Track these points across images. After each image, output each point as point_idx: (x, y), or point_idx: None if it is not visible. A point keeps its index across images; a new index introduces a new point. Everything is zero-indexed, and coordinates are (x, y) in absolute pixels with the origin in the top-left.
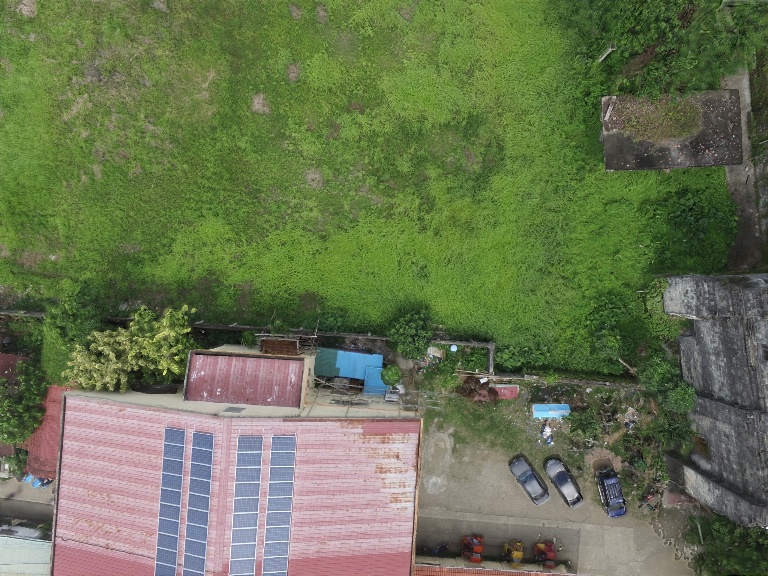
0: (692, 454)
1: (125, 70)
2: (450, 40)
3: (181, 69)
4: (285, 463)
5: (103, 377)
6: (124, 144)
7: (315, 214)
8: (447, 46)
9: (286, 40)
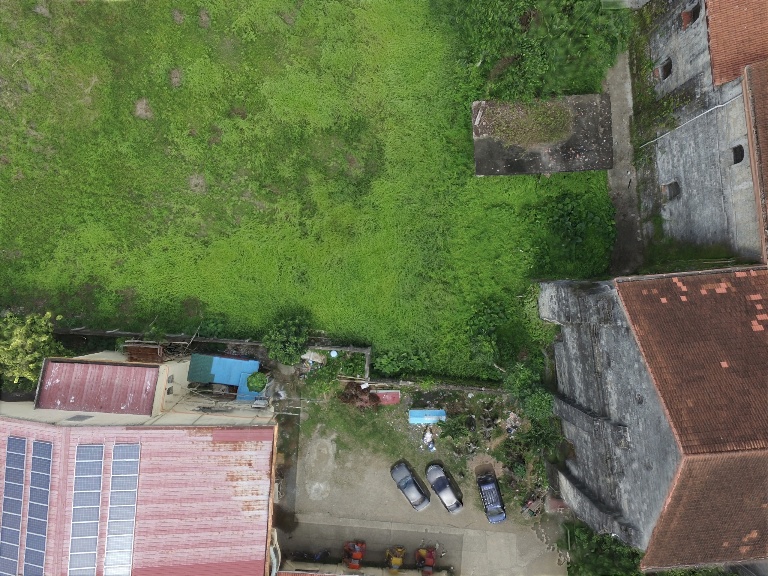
0: (567, 459)
1: (7, 75)
2: (331, 45)
3: (63, 74)
4: (128, 472)
5: None
6: (6, 150)
7: (197, 219)
8: (327, 51)
9: (168, 45)
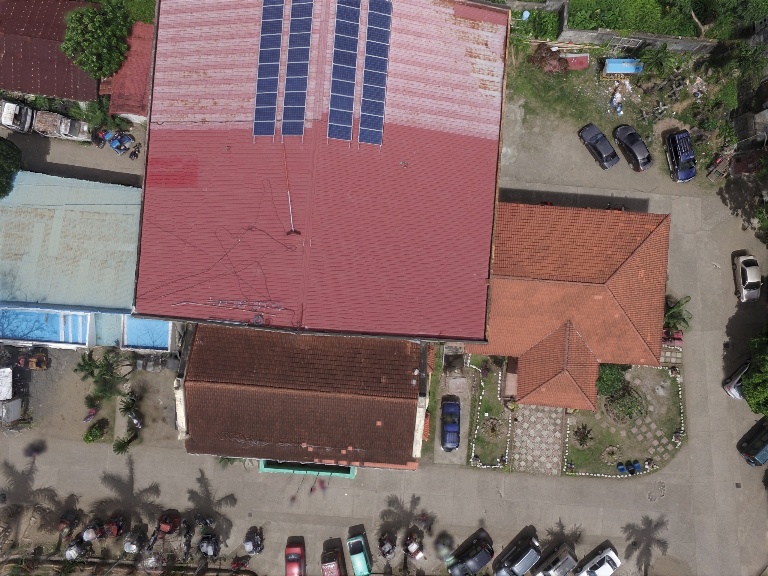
0: (764, 103)
1: None
2: None
3: None
4: (381, 26)
5: None
6: None
7: None
8: None
9: None
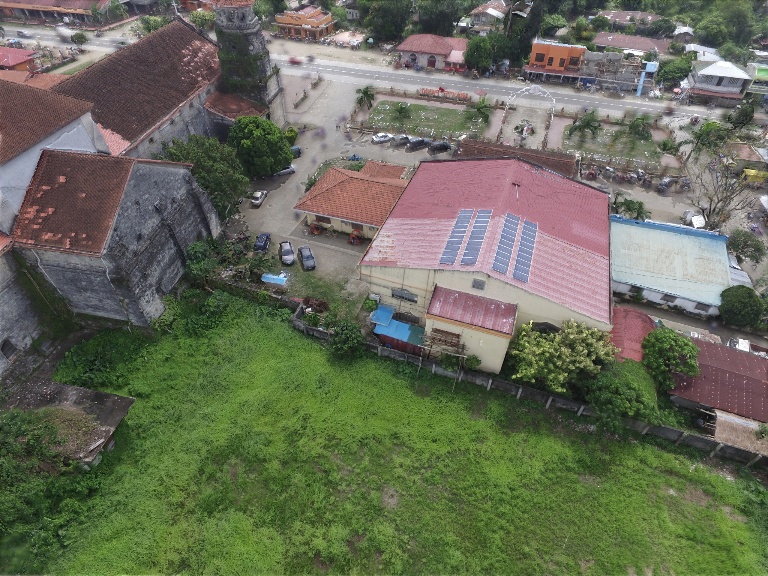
0: None
1: None
2: None
3: None
4: None
5: (581, 331)
6: None
7: (399, 460)
8: None
9: None
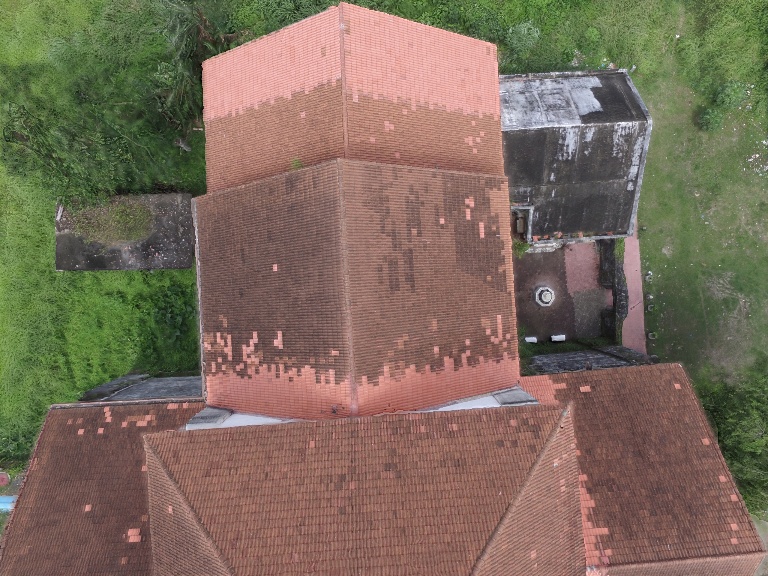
0: None
1: None
2: None
3: None
4: None
5: None
6: None
7: None
8: None
9: None
